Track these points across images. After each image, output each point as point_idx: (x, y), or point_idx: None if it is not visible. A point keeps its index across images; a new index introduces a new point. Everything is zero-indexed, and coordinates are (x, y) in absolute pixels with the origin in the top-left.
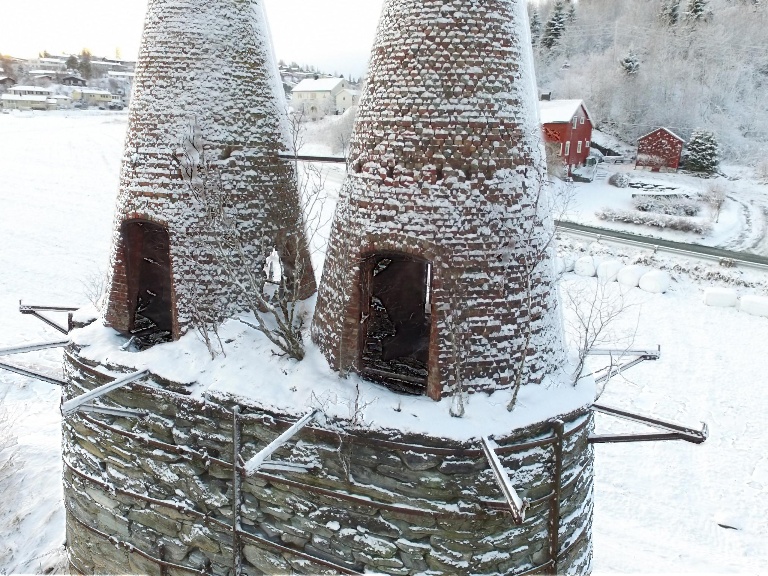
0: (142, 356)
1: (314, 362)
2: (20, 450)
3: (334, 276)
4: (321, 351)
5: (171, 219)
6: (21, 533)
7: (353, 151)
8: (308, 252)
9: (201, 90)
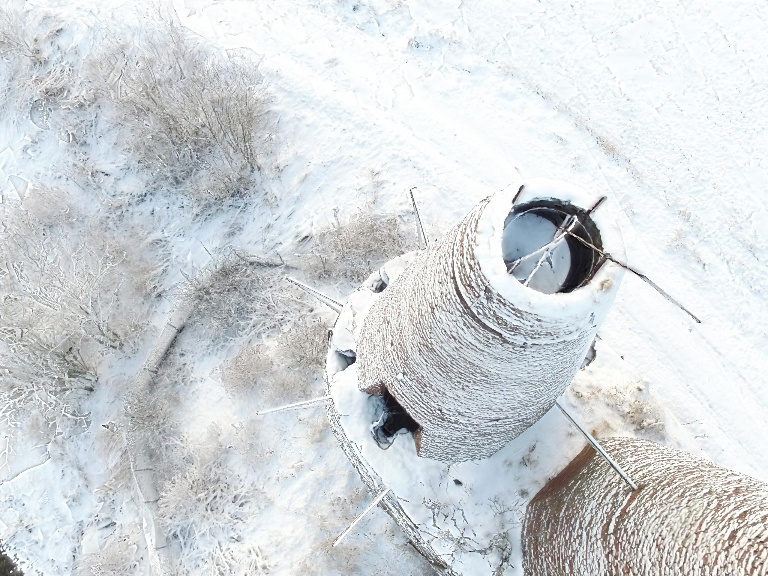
0: (388, 468)
1: (514, 570)
2: (277, 130)
3: (551, 573)
4: (523, 565)
5: (426, 427)
6: (282, 182)
7: (613, 568)
8: None
9: (483, 396)
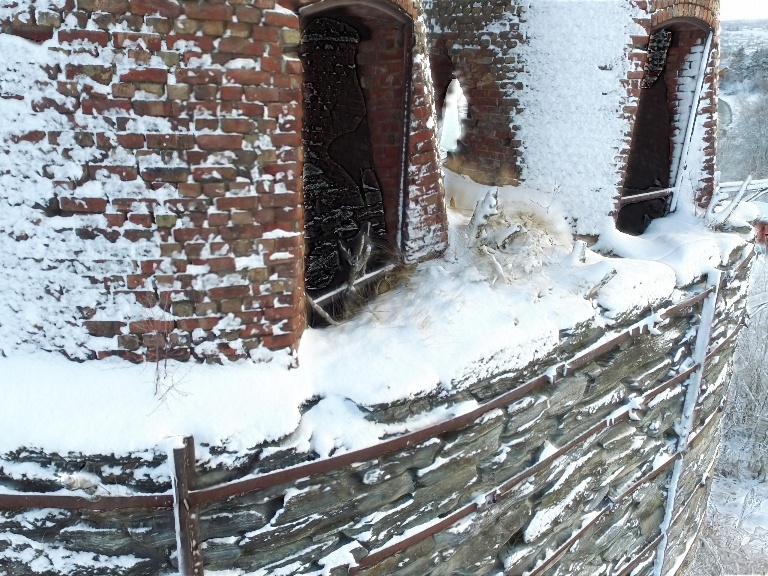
0: None
1: None
2: None
3: None
4: None
5: None
6: None
7: None
8: (507, 97)
9: None
